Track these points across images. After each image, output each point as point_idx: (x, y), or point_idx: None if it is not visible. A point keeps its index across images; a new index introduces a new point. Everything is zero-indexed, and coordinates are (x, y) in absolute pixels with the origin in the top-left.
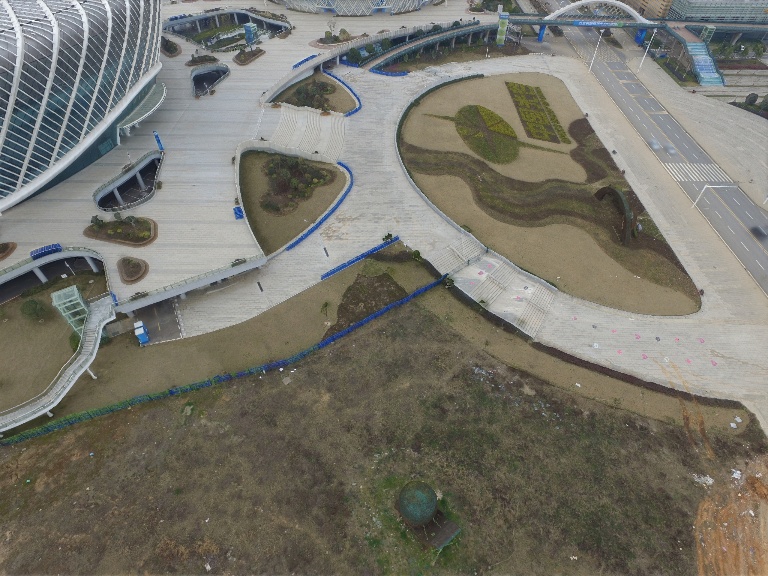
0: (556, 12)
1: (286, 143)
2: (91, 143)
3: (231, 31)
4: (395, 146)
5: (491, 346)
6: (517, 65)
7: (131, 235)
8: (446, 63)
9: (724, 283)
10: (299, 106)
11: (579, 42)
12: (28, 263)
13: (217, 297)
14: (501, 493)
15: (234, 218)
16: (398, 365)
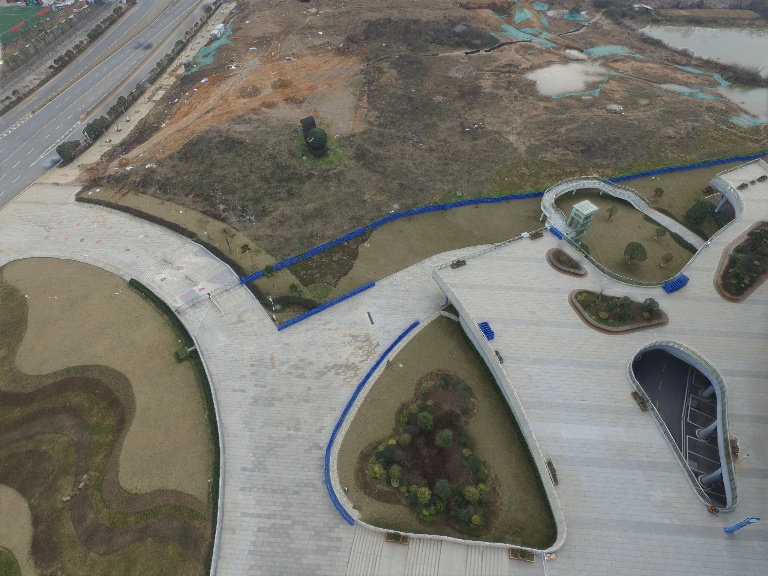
0: None
1: (470, 574)
2: None
3: None
4: None
5: (231, 234)
6: None
7: None
8: None
9: None
10: None
11: None
12: None
13: None
14: (271, 157)
15: None
16: (312, 216)
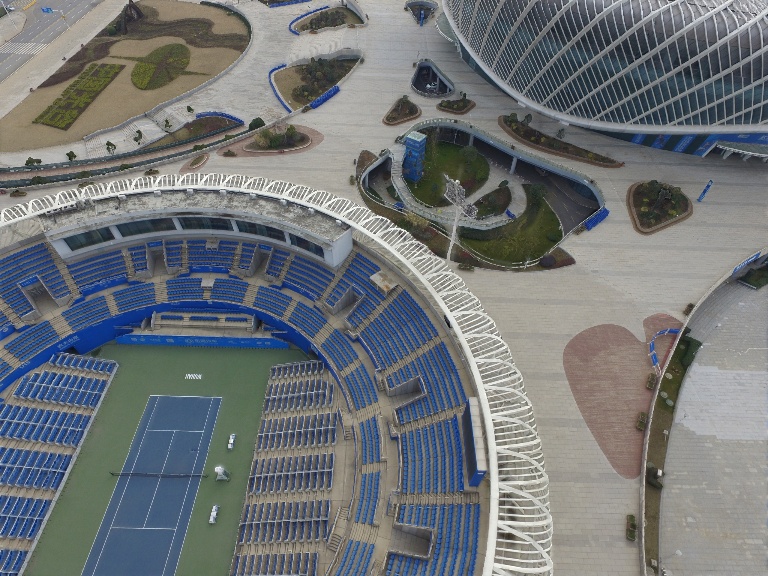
0: None
1: None
2: None
3: None
4: None
5: None
6: (3, 166)
7: None
8: None
9: (113, 6)
10: None
11: None
12: None
13: None
14: None
15: None
16: None
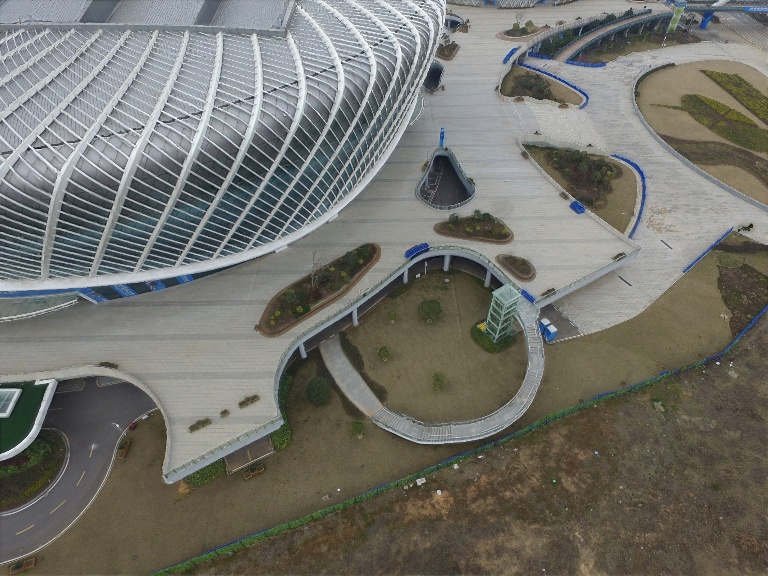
0: None
1: (555, 137)
2: None
3: None
4: (655, 137)
5: None
6: (698, 53)
7: (493, 232)
8: (628, 53)
9: None
10: None
11: (741, 28)
12: (408, 263)
13: (588, 293)
14: None
15: (575, 213)
16: None
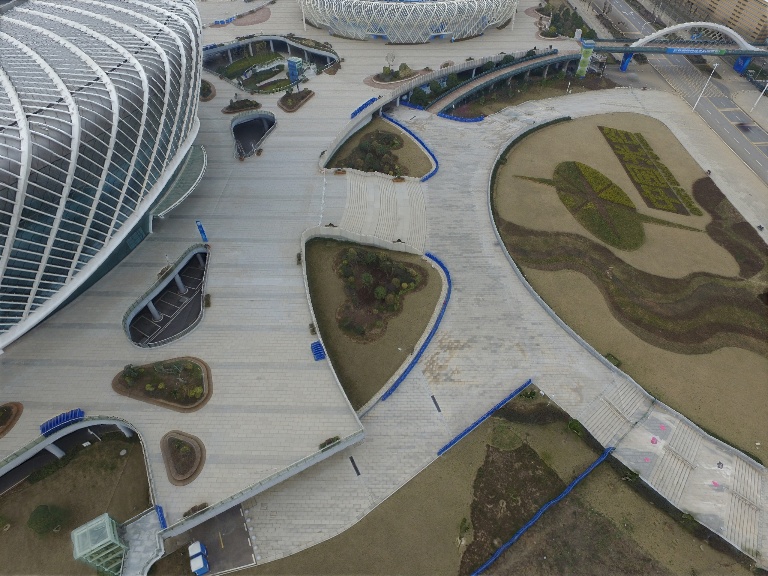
0: (646, 38)
1: (359, 227)
2: (119, 243)
3: (267, 61)
4: (493, 227)
5: None
6: (605, 103)
7: (178, 394)
8: (522, 101)
9: None
10: (365, 169)
11: (668, 71)
12: (38, 443)
13: (297, 484)
14: None
15: (312, 359)
16: None
